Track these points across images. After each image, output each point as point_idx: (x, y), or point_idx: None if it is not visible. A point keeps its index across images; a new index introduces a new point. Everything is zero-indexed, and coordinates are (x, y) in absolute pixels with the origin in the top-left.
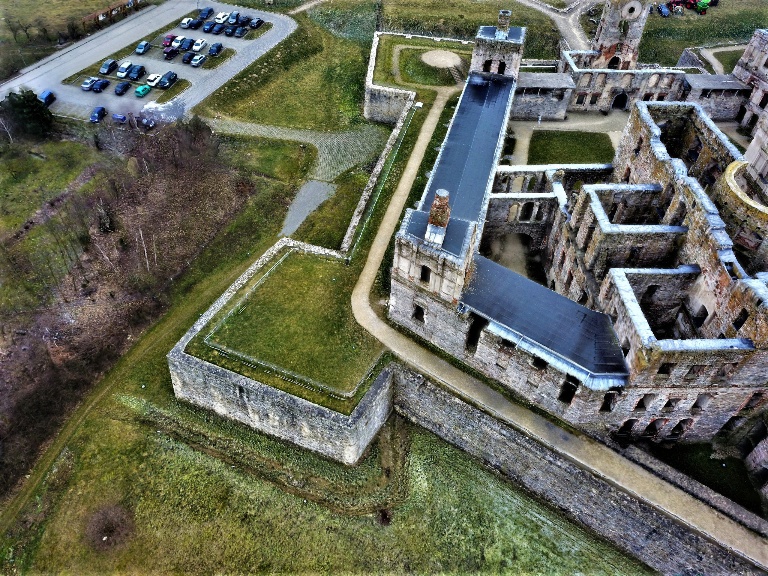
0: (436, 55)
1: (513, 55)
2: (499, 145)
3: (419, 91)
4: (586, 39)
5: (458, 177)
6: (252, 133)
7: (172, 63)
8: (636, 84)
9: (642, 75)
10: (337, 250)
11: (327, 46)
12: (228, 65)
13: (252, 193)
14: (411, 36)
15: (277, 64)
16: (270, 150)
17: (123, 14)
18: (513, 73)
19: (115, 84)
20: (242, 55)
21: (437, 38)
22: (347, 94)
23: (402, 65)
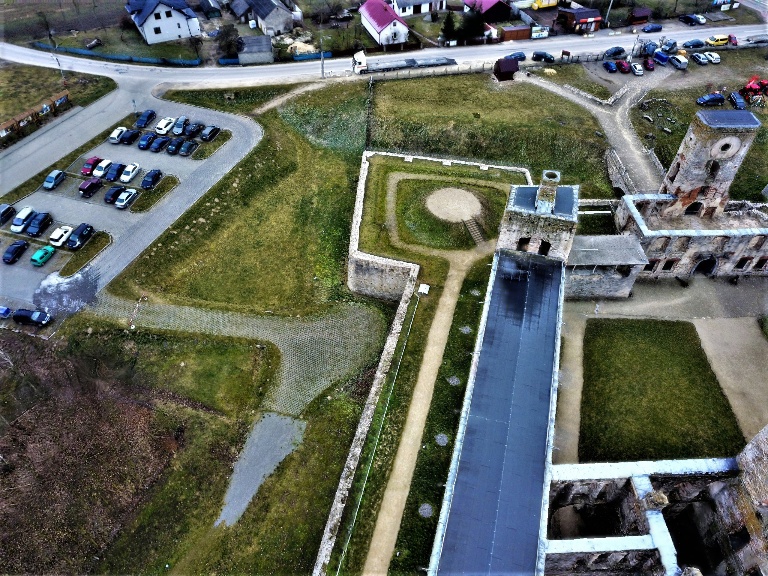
0: (446, 198)
1: (562, 234)
2: (551, 414)
3: (424, 261)
4: (641, 147)
5: (491, 508)
6: (189, 326)
7: (91, 203)
8: (730, 248)
9: (740, 238)
10: (301, 567)
11: (302, 162)
12: (166, 204)
13: (180, 445)
14: (412, 158)
15: (233, 198)
16: (213, 355)
17: (36, 123)
18: (561, 255)
19: (7, 244)
20: (186, 186)
21: (447, 161)
22: (326, 245)
23: (400, 210)
